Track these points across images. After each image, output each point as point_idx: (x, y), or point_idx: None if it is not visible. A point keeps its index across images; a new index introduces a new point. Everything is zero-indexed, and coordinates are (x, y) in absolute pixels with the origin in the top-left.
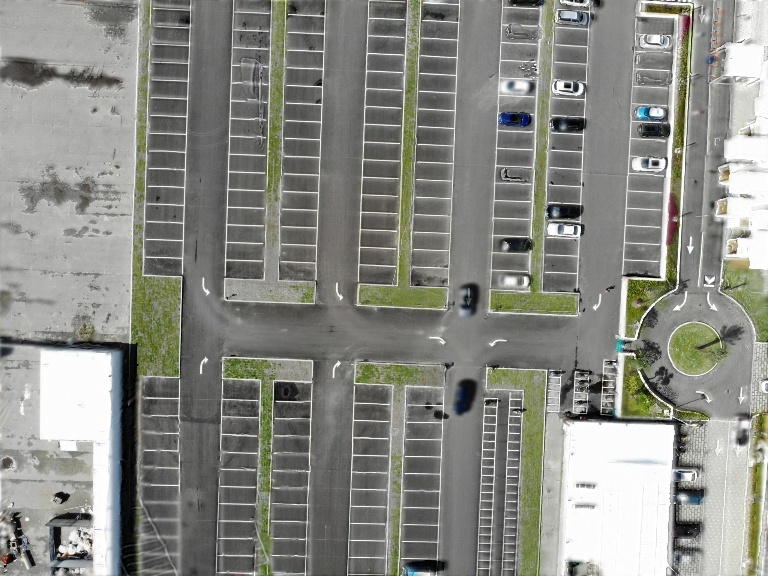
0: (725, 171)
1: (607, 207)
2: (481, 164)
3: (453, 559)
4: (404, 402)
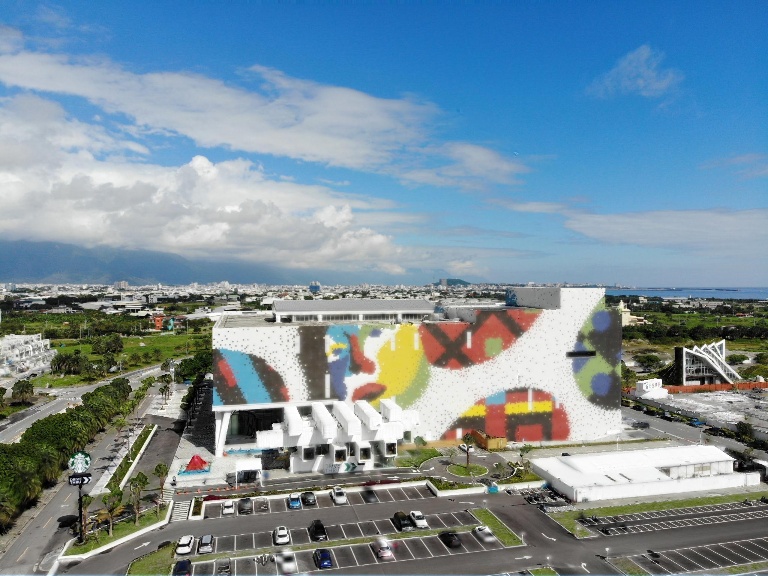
0: (337, 459)
1: (385, 510)
2: (381, 572)
3: (761, 530)
4: (673, 575)
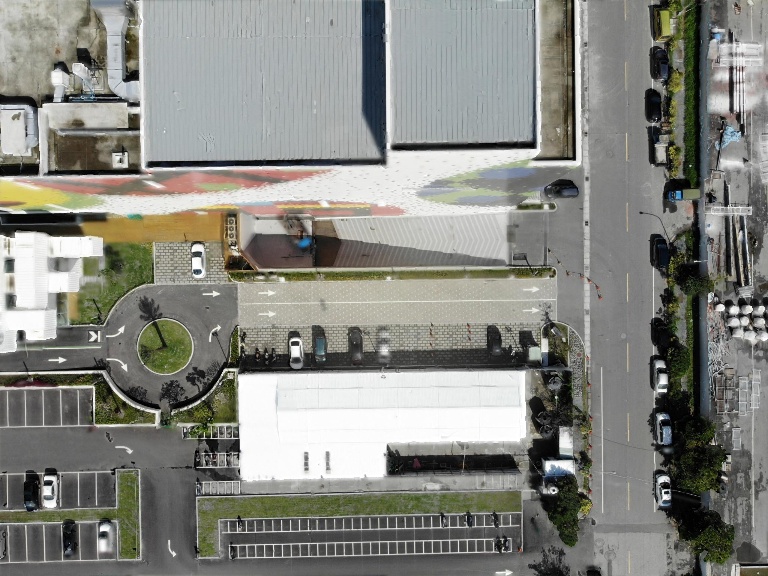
0: None
1: (27, 446)
2: None
3: None
4: None
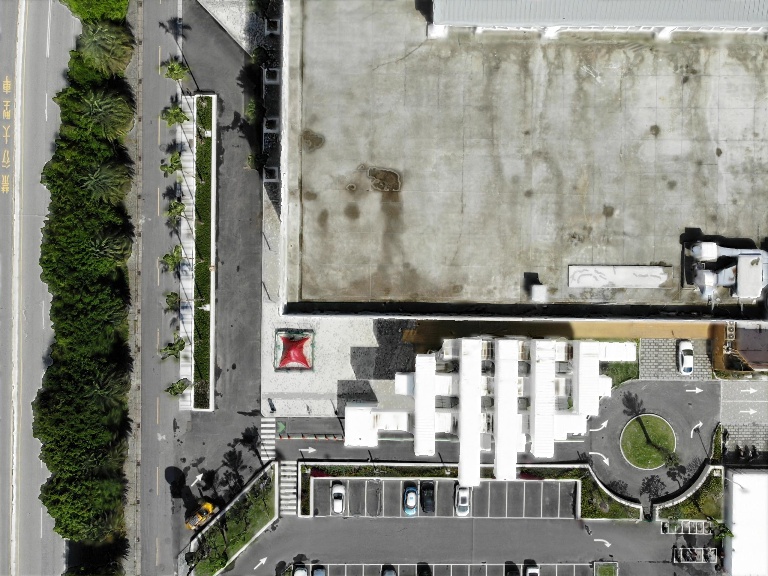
0: None
1: (506, 537)
2: None
3: None
4: None
